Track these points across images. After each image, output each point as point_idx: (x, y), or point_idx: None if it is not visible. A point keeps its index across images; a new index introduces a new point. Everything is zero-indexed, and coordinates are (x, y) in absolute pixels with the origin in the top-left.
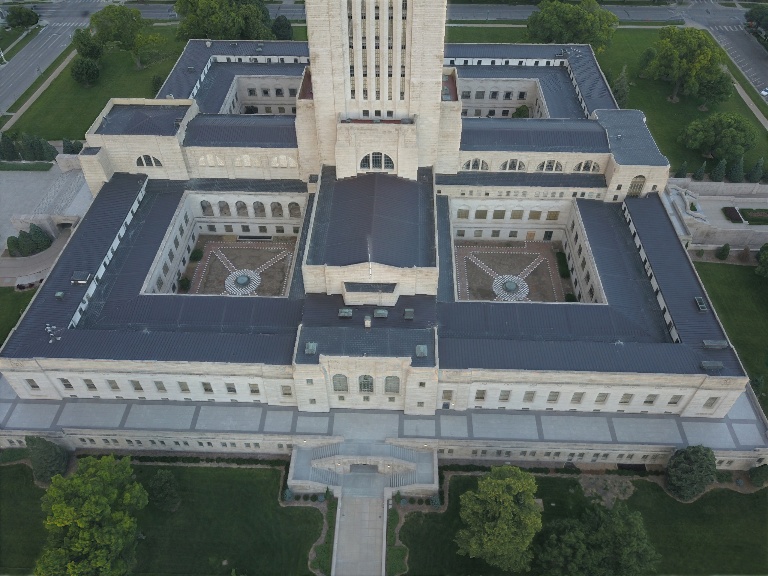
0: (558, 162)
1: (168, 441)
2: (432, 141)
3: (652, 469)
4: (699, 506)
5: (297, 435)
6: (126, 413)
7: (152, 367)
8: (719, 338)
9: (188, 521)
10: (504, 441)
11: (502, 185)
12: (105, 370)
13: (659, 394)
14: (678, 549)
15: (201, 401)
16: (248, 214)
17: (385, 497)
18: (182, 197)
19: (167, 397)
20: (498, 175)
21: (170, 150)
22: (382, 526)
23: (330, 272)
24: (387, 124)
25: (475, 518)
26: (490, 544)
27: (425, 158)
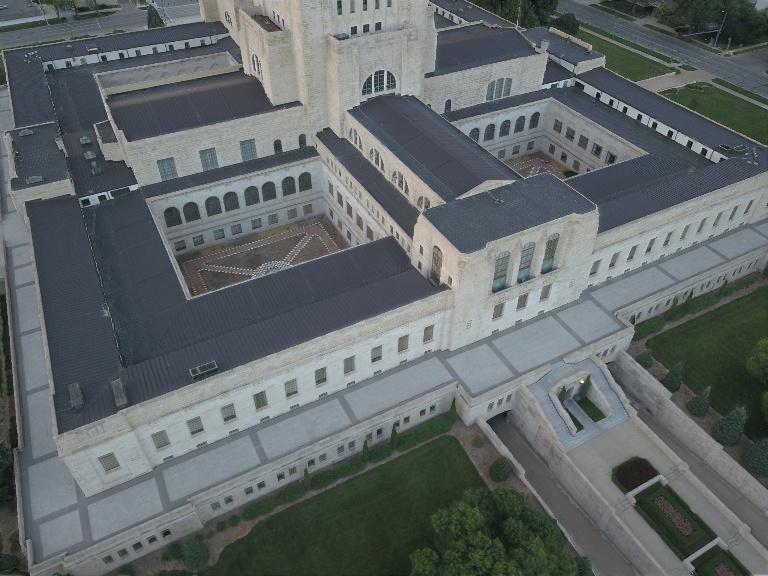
0: None
1: None
2: (302, 72)
3: None
4: None
5: None
6: None
7: None
8: (139, 400)
9: None
10: (8, 306)
11: (350, 171)
12: None
13: None
14: None
15: None
16: None
17: None
18: (218, 53)
19: None
20: (364, 162)
21: None
22: None
23: None
24: (257, 23)
25: None
26: None
27: (301, 92)
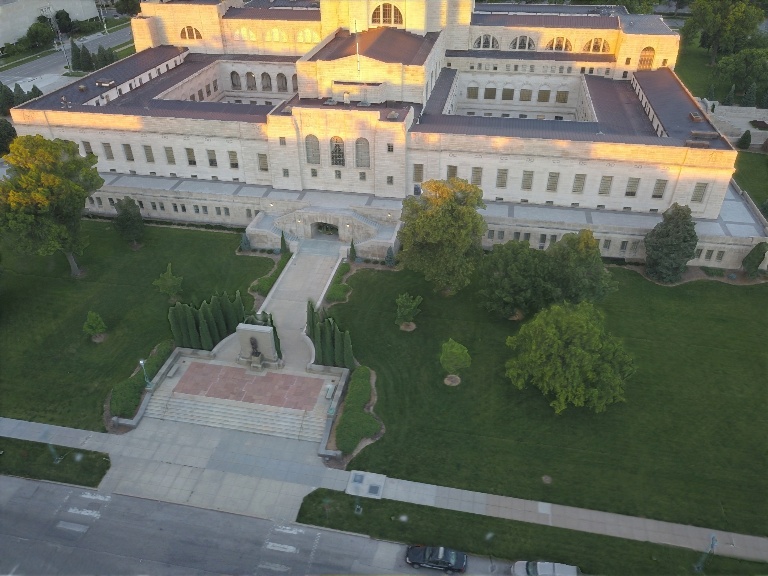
0: (567, 40)
1: (146, 202)
2: (441, 2)
3: (632, 261)
4: (681, 289)
5: (265, 197)
6: (115, 180)
7: (143, 124)
8: None
9: (145, 256)
10: None
11: (510, 59)
12: (102, 128)
13: (640, 178)
14: (649, 315)
15: (185, 178)
16: (272, 88)
17: (340, 255)
18: (214, 62)
19: (155, 171)
20: (508, 53)
21: (210, 20)
22: (331, 272)
23: (321, 67)
24: None
25: (414, 217)
26: (422, 225)
27: (435, 22)
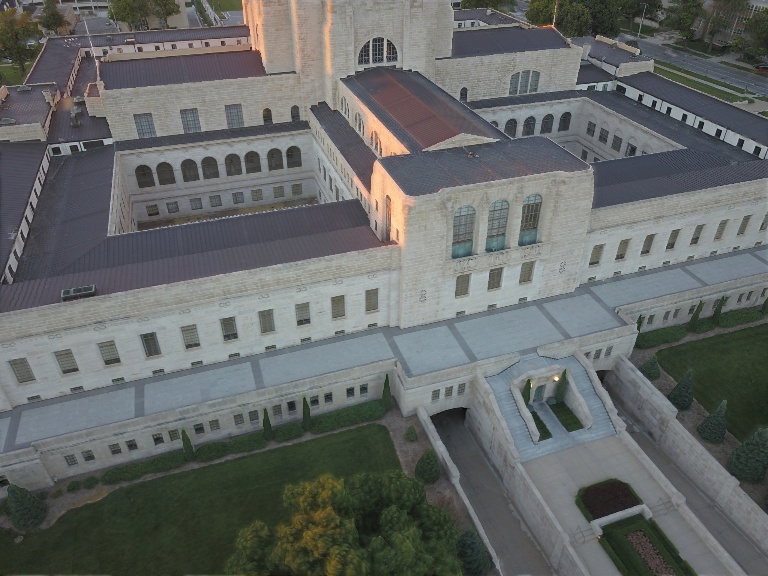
0: None
1: None
2: None
3: None
4: None
5: None
6: None
7: None
8: None
9: None
10: None
11: (332, 137)
12: None
13: None
14: None
15: None
16: None
17: None
18: None
19: None
20: (349, 131)
21: None
22: None
23: None
24: None
25: None
26: None
27: None
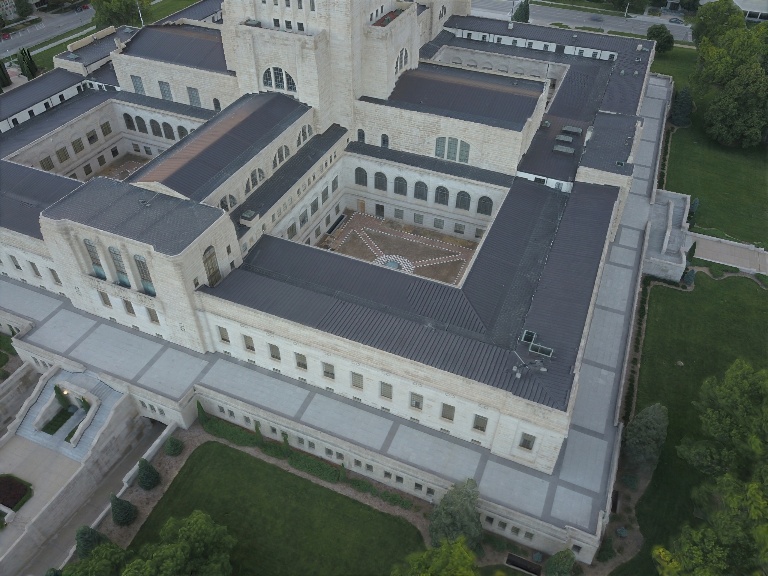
0: None
1: None
2: None
3: None
4: None
5: None
6: None
7: None
8: None
9: None
10: None
11: None
12: None
13: None
14: None
15: None
16: None
17: None
18: None
19: None
20: None
21: None
22: None
23: None
24: None
25: None
26: None
27: None
